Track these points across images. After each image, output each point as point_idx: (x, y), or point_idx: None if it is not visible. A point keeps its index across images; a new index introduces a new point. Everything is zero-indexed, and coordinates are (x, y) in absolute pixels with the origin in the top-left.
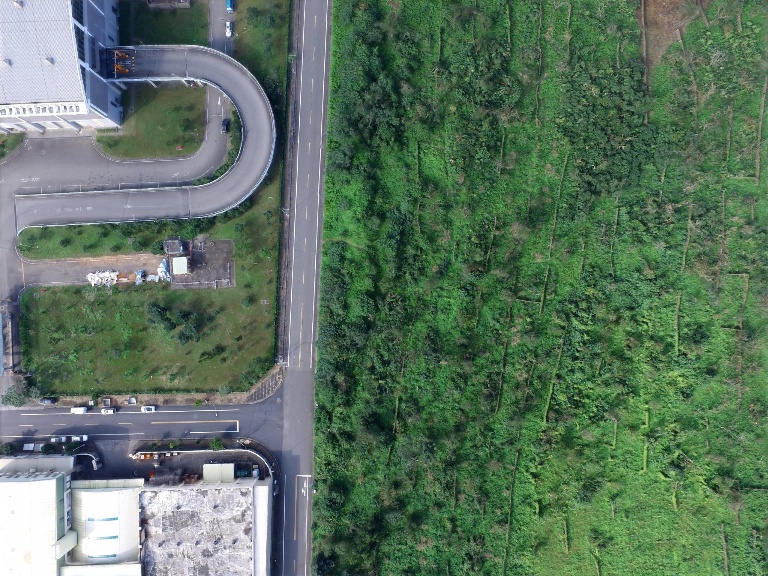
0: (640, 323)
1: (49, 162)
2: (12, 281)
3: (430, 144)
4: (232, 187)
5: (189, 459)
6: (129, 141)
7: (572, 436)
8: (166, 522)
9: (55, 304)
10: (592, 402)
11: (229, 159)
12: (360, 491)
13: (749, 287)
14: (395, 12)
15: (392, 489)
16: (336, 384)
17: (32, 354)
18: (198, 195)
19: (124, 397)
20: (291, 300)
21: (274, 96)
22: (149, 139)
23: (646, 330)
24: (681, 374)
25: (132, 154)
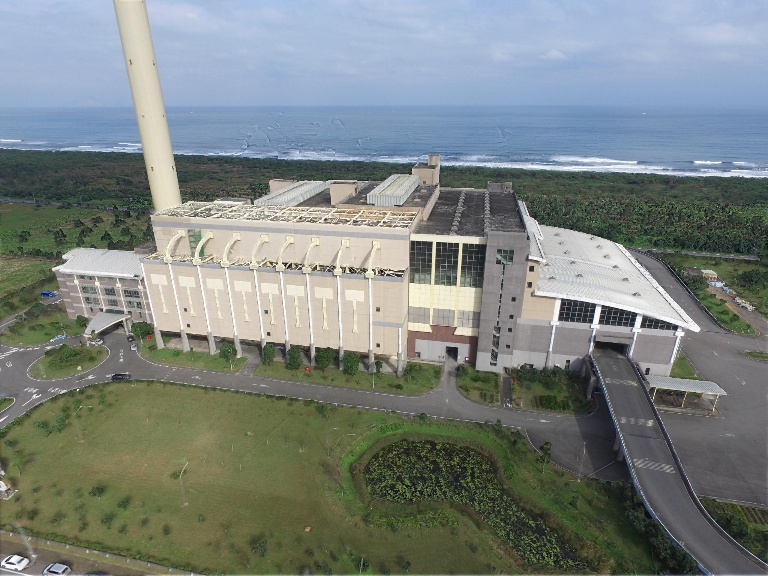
0: None
1: None
2: None
3: None
4: None
5: None
6: None
7: None
8: None
9: None
10: None
11: None
12: None
13: None
14: None
15: None
16: None
17: None
18: (649, 265)
19: None
20: None
21: None
22: None
23: None
24: None
25: None
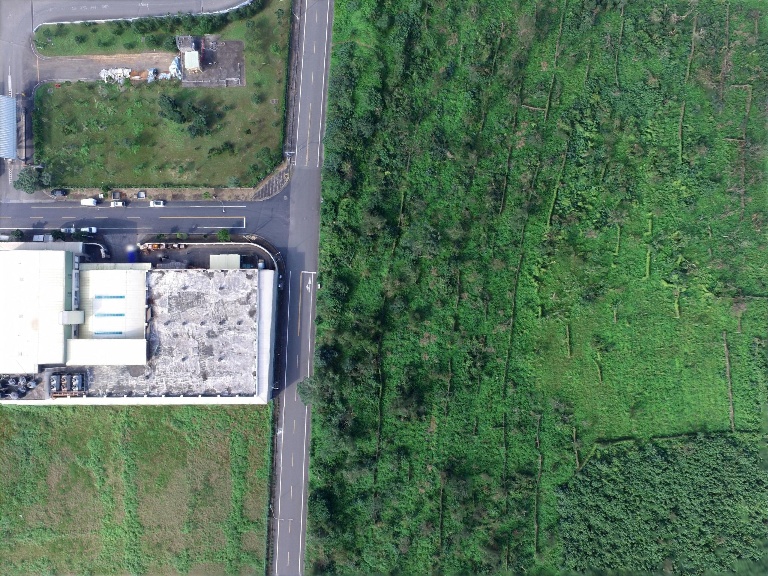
0: (644, 133)
1: None
2: (27, 77)
3: None
4: None
5: (196, 253)
6: None
7: (575, 243)
8: (172, 302)
9: (68, 99)
10: (595, 209)
11: None
12: (364, 288)
13: (752, 99)
14: None
15: (396, 281)
16: (342, 175)
17: (44, 148)
18: None
19: (133, 191)
20: (300, 100)
21: None
22: None
23: (650, 140)
24: (684, 183)
25: None
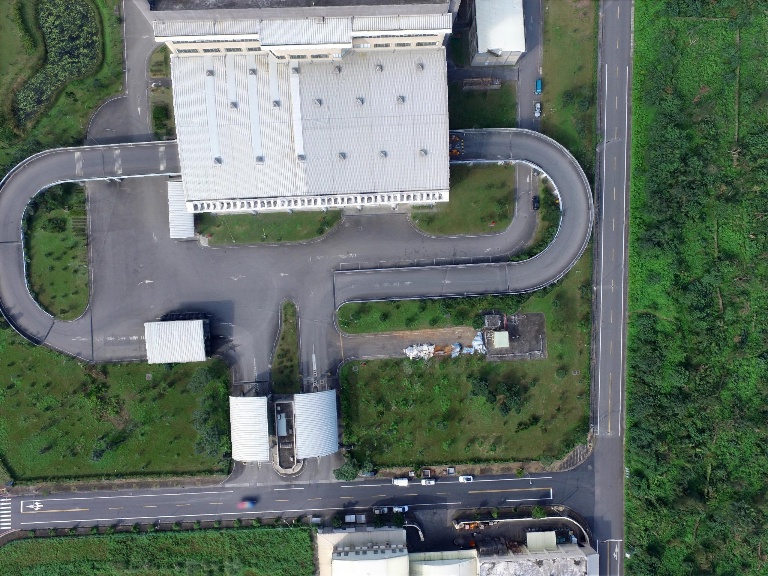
0: None
1: (366, 238)
2: (331, 355)
3: (728, 220)
4: (550, 263)
5: (506, 527)
6: (444, 217)
7: None
8: None
9: (374, 377)
10: None
11: (548, 236)
12: (670, 554)
13: None
14: (698, 96)
15: (708, 553)
16: (656, 453)
17: (352, 427)
18: (516, 271)
19: (442, 467)
20: (599, 370)
21: (588, 176)
22: (463, 215)
23: None
24: None
25: (446, 230)
